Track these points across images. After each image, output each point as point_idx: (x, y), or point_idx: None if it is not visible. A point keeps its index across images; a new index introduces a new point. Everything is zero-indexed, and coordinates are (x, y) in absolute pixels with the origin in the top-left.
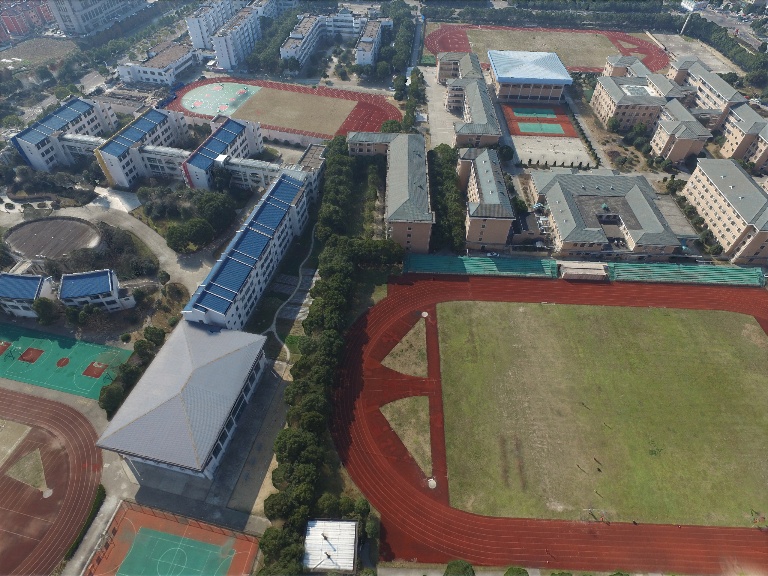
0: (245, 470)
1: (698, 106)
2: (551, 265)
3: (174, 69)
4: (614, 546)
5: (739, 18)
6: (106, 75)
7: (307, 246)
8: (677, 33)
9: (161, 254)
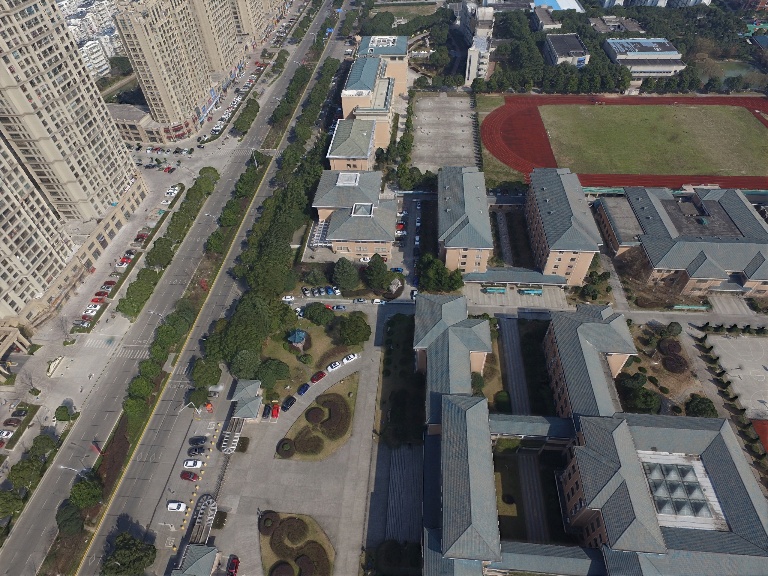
0: None
1: None
2: None
3: None
4: None
5: None
6: None
7: None
8: None
9: None
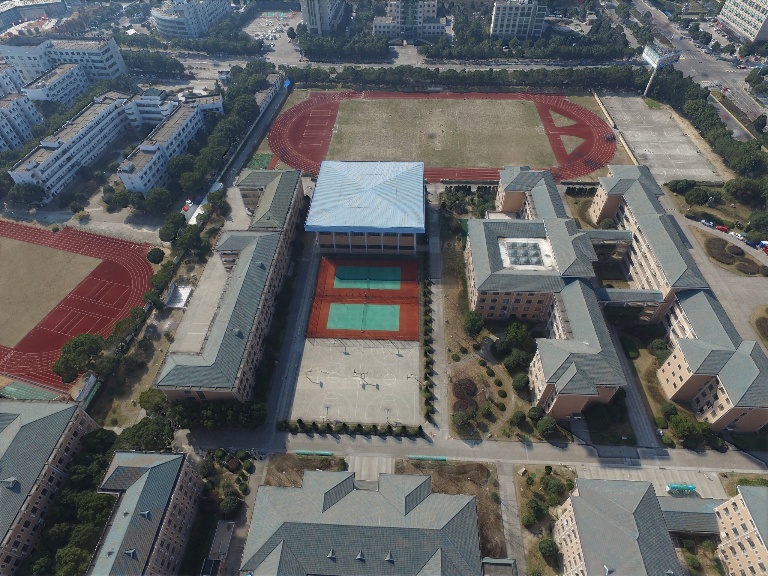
0: None
1: (633, 266)
2: None
3: None
4: None
5: (734, 62)
6: None
7: None
8: (639, 94)
9: None
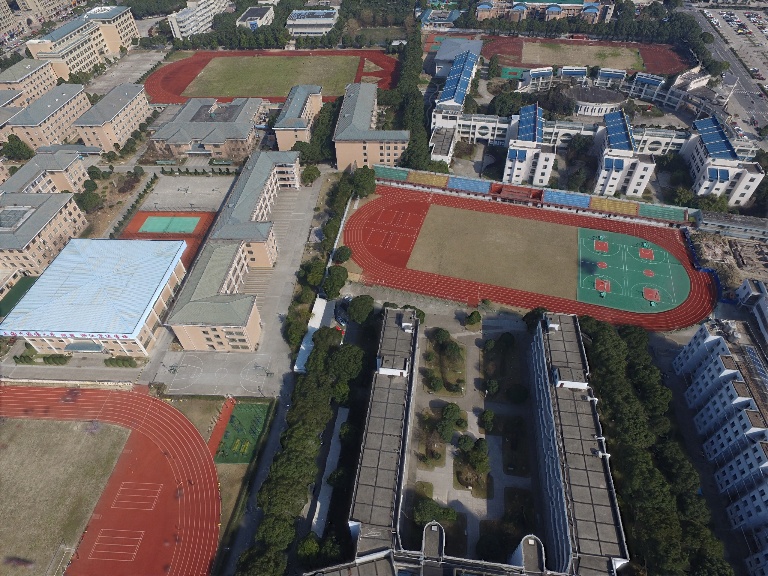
0: None
1: None
2: None
3: (759, 304)
4: None
5: None
6: None
7: (430, 114)
8: None
9: None
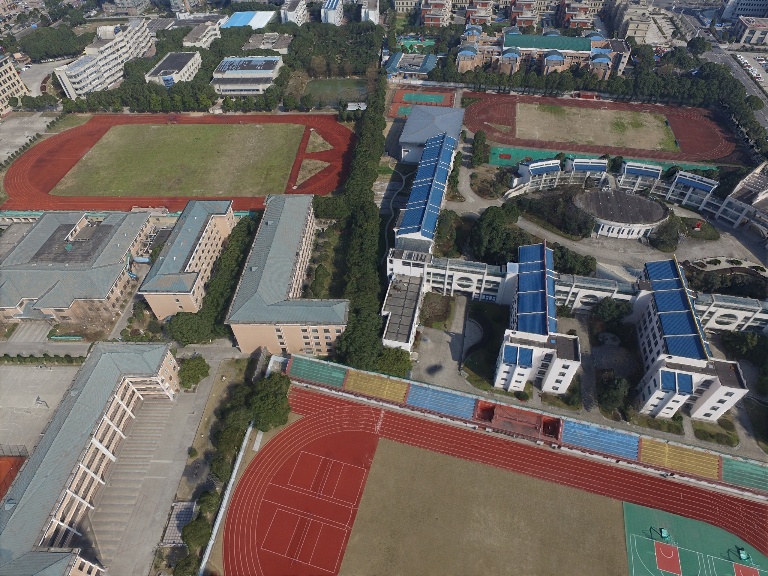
0: (400, 130)
1: None
2: (173, 214)
3: None
4: (242, 119)
5: None
6: None
7: (391, 232)
8: None
9: (522, 221)
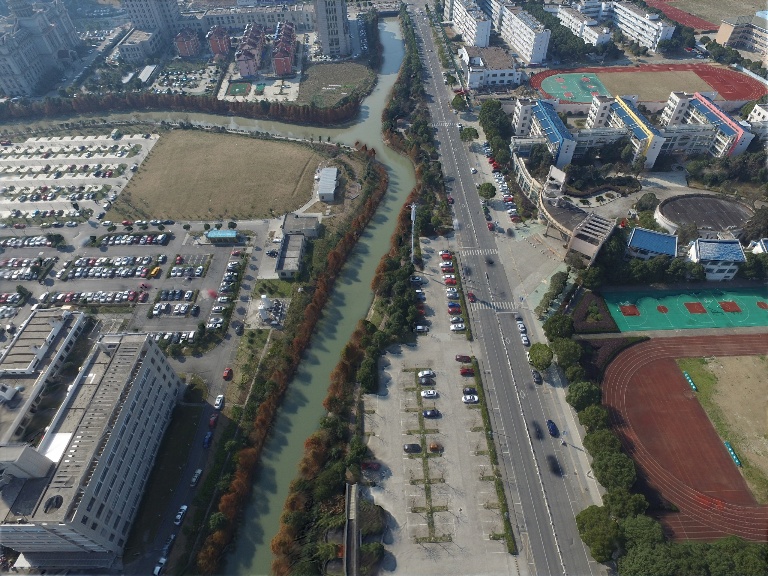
0: None
1: None
2: None
3: None
4: None
5: None
6: (455, 84)
7: None
8: None
9: None
